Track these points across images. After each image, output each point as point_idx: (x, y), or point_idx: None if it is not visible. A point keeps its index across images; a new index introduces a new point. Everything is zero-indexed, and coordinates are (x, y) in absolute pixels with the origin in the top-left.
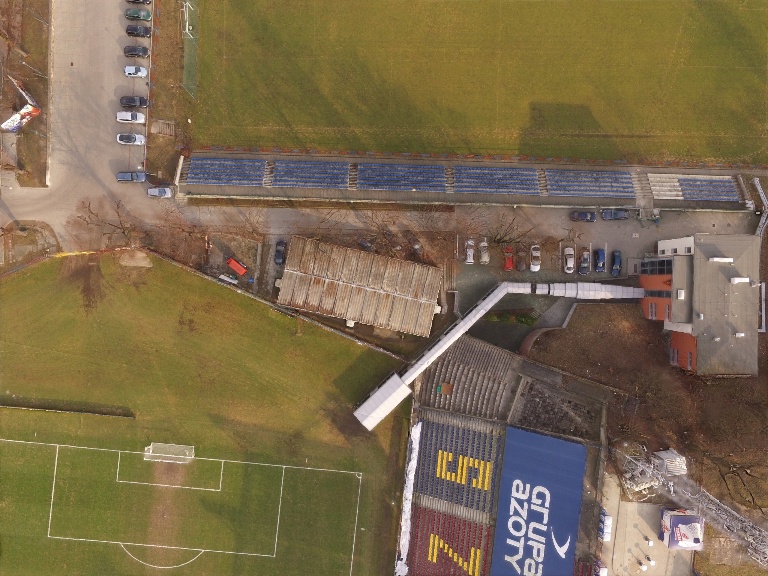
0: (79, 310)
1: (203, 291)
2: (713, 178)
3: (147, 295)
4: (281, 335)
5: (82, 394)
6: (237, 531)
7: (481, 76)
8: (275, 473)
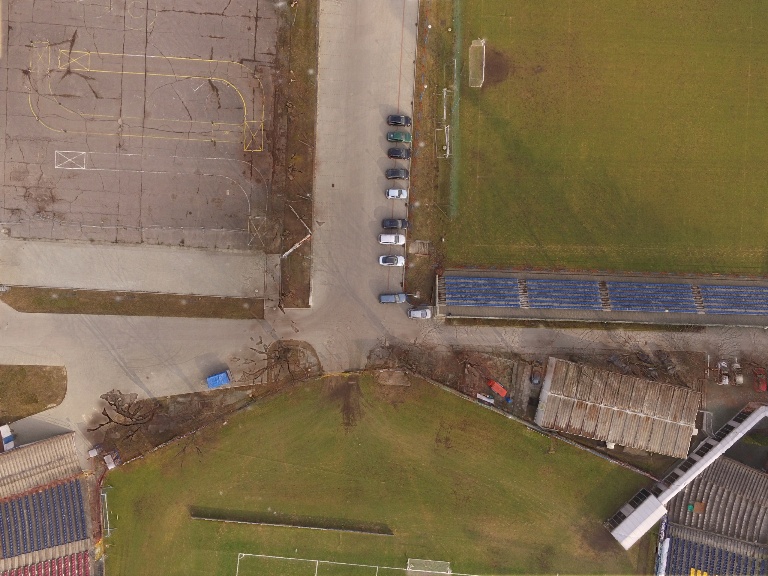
0: (339, 428)
1: (459, 409)
2: None
3: (405, 413)
4: (534, 453)
5: (341, 511)
6: None
7: (726, 195)
8: None
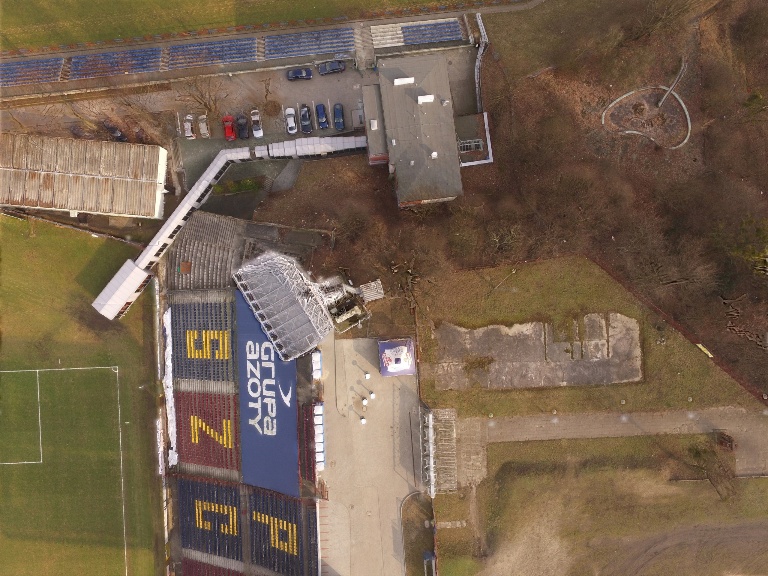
0: None
1: None
2: (438, 22)
3: None
4: (15, 239)
5: None
6: None
7: None
8: (29, 378)
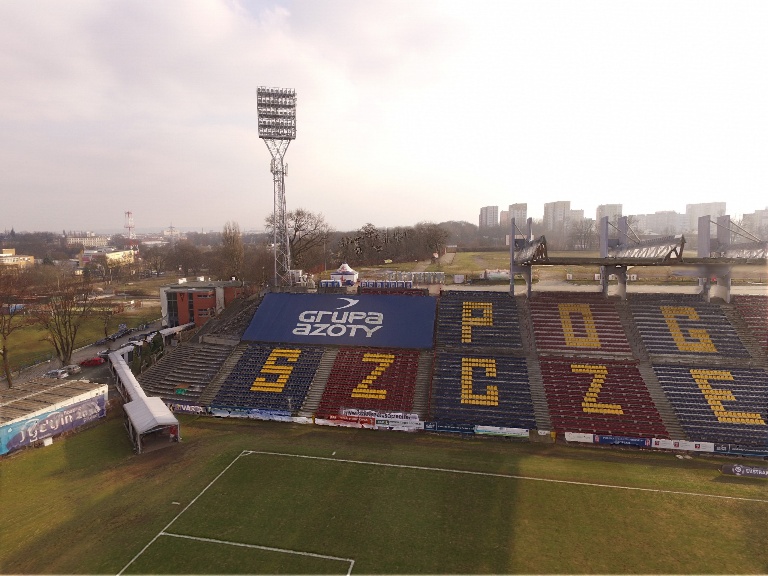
0: None
1: None
2: None
3: None
4: None
5: None
6: None
7: None
8: (163, 548)
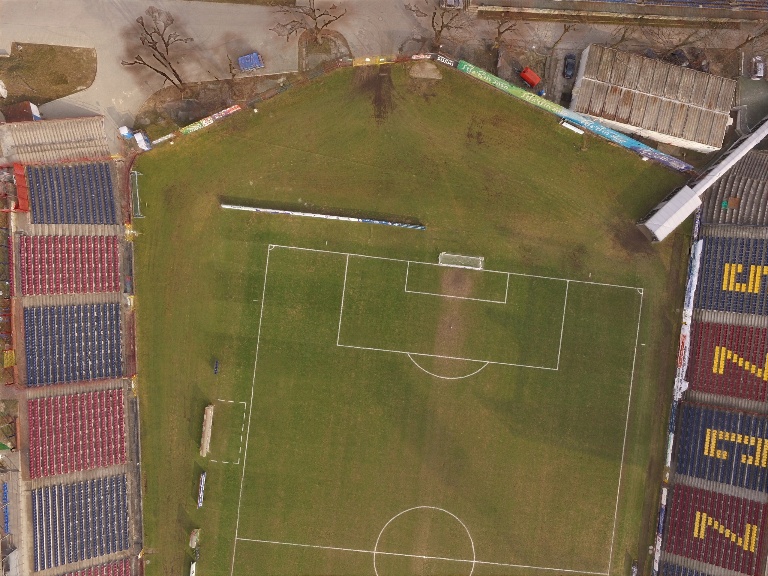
0: (370, 120)
1: (491, 104)
2: None
3: (437, 107)
4: (567, 150)
5: (372, 204)
6: (521, 344)
7: None
8: (559, 287)
